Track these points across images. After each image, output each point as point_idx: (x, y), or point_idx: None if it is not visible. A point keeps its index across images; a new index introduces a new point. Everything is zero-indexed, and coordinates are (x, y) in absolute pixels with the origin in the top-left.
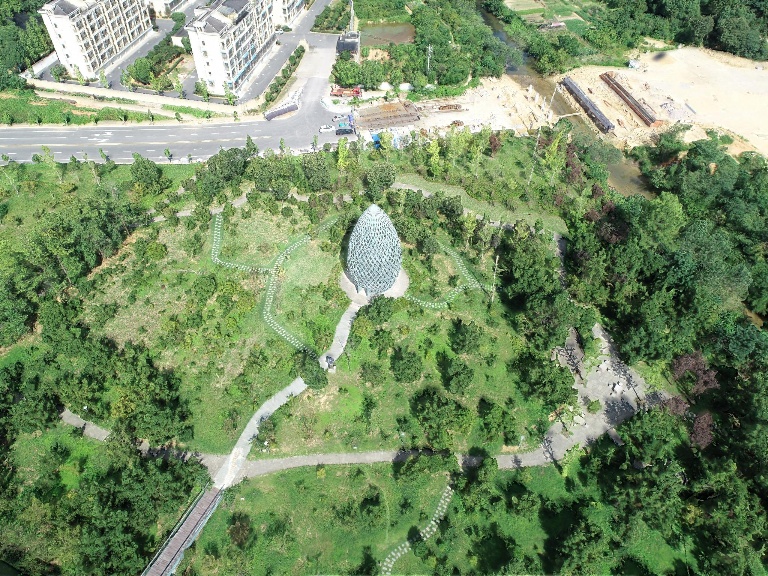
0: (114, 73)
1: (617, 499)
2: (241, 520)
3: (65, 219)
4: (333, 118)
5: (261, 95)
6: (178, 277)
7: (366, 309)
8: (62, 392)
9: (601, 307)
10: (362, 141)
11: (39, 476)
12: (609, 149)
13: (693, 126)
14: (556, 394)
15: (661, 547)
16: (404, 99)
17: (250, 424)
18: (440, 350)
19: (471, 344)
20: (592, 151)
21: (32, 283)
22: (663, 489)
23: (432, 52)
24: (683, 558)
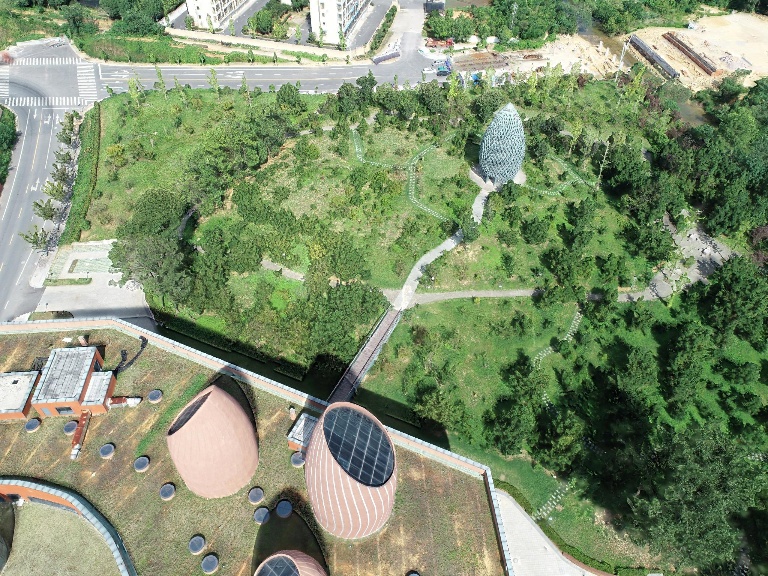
0: (234, 25)
1: (715, 316)
2: None
3: (240, 123)
4: (433, 63)
5: (368, 43)
6: (334, 171)
7: None
8: (266, 242)
9: (686, 199)
10: (469, 75)
11: (253, 302)
12: (680, 88)
13: (751, 74)
14: (661, 248)
15: (750, 352)
16: (491, 50)
17: (414, 270)
18: (559, 223)
19: (587, 216)
20: (666, 89)
21: (227, 166)
22: (754, 302)
23: (517, 9)
24: (767, 358)
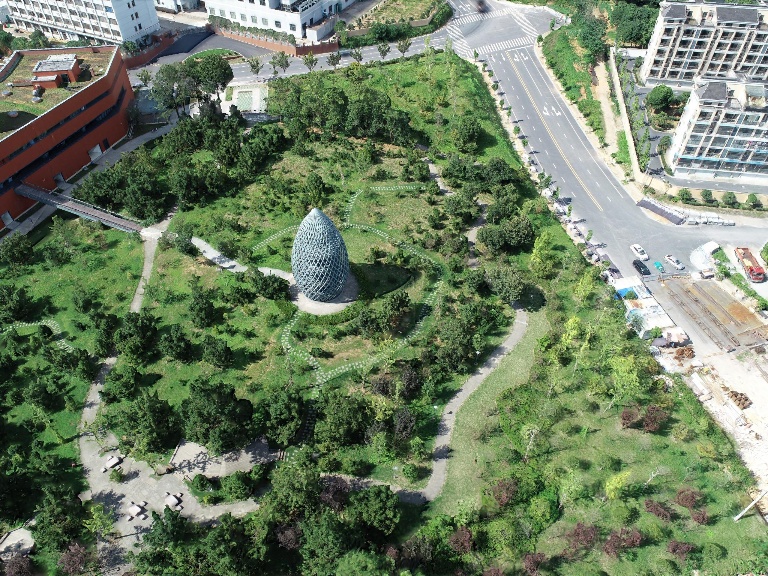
0: None
1: None
2: (115, 245)
3: None
4: None
5: (677, 186)
6: None
7: (281, 282)
8: None
9: None
10: (570, 259)
11: None
12: None
13: None
14: None
15: None
16: None
17: None
18: None
19: None
20: None
21: None
22: None
23: None
24: None
